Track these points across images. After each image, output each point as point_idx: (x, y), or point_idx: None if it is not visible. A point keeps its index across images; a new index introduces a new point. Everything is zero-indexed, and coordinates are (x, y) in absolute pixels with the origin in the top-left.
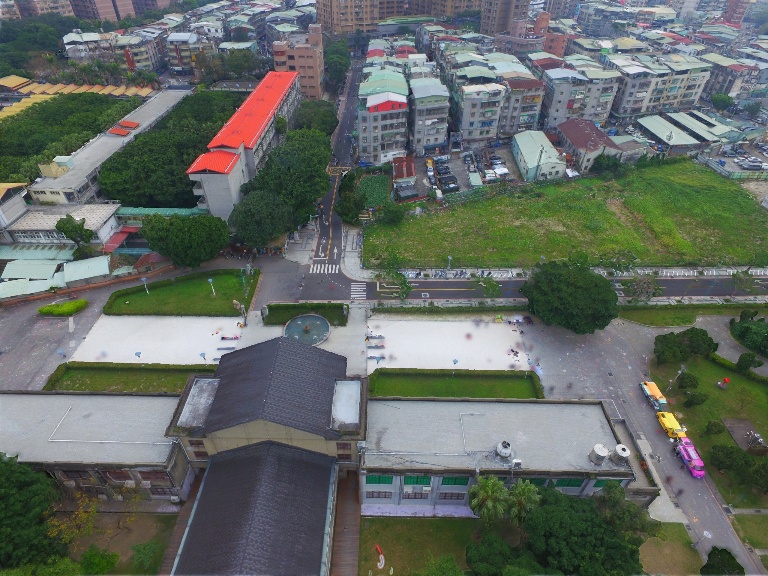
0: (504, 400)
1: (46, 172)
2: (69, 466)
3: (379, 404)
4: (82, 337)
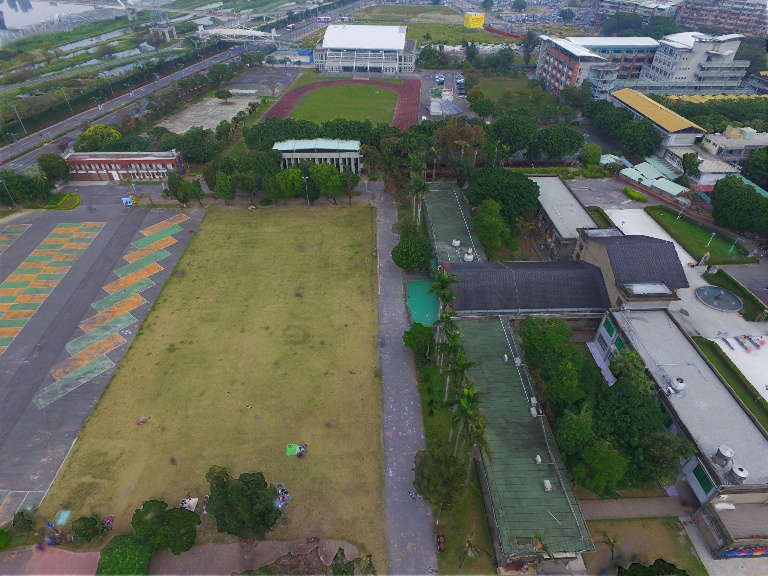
0: (734, 394)
1: (728, 132)
2: (545, 214)
3: (666, 317)
4: (621, 208)
